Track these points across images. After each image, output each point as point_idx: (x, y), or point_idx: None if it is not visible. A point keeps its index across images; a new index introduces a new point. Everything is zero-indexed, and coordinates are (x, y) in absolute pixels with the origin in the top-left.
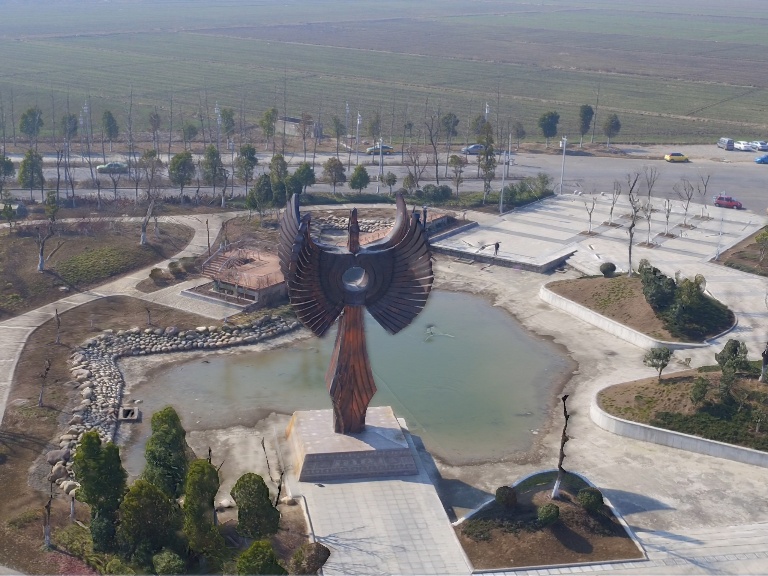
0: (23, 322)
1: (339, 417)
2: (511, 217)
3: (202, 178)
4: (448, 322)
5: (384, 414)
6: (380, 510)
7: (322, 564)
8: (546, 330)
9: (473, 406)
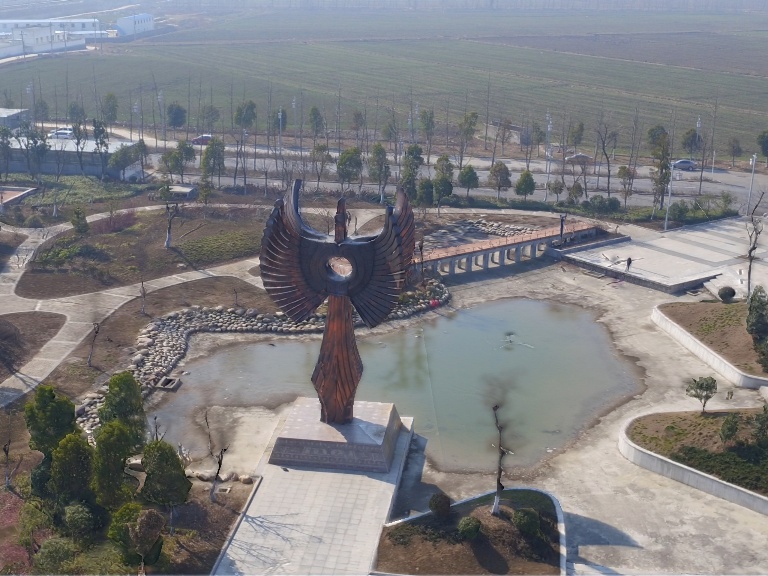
0: (127, 291)
1: (323, 406)
2: (673, 234)
3: (368, 174)
4: (537, 333)
5: (381, 410)
6: (325, 501)
7: (155, 531)
8: (635, 351)
9: (505, 417)
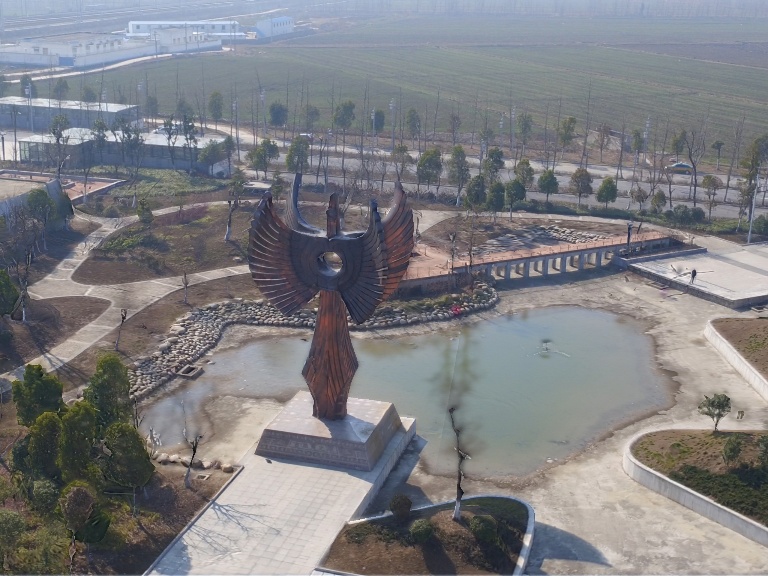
0: (177, 281)
1: (315, 401)
2: (755, 248)
3: (448, 176)
4: (578, 341)
5: (377, 408)
6: (297, 494)
7: (83, 508)
8: (676, 365)
9: (516, 424)
